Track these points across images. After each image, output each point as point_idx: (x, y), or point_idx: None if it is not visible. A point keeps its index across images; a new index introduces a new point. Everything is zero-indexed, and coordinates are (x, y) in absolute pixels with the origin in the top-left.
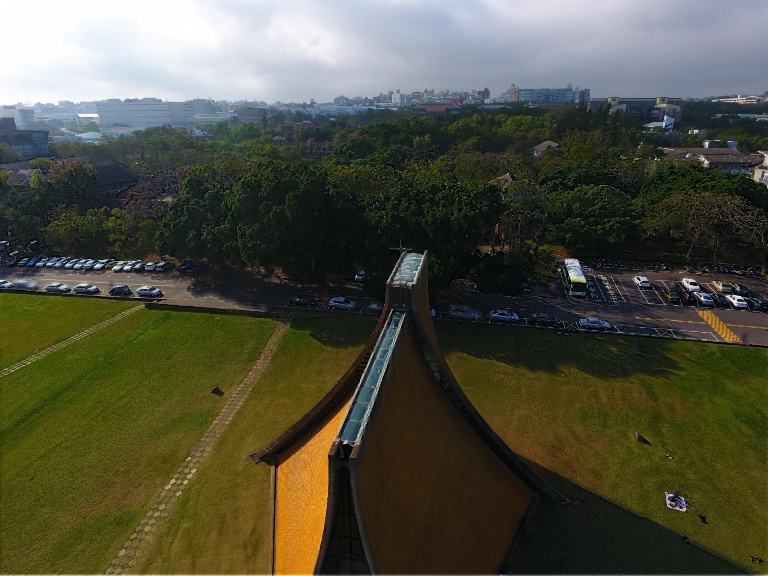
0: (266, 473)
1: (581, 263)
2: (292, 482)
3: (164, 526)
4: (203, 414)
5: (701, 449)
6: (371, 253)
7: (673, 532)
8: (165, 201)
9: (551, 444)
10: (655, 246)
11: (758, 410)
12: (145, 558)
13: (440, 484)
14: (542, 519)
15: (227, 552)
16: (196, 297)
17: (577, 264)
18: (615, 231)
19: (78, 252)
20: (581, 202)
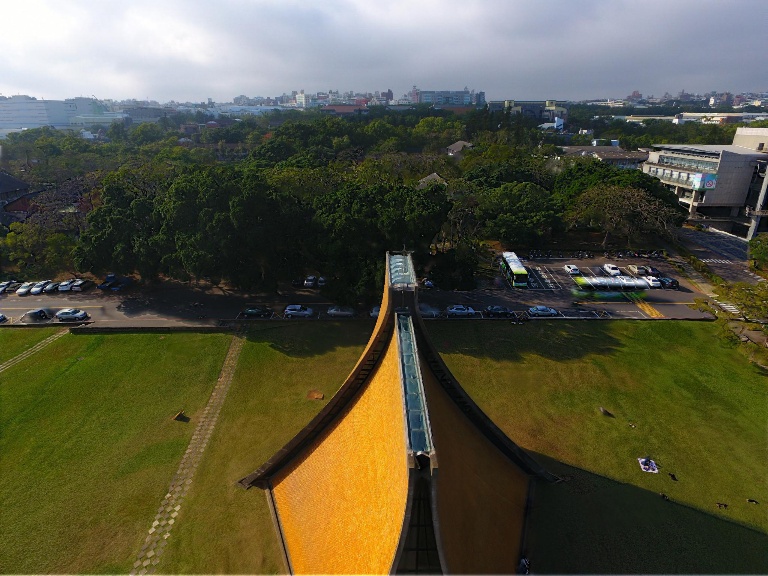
0: (261, 498)
1: None
2: (297, 503)
3: (159, 575)
4: (172, 444)
5: (655, 415)
6: (325, 257)
7: (653, 493)
8: (77, 212)
9: (531, 428)
10: (575, 236)
11: (691, 375)
12: None
13: (463, 481)
14: (543, 500)
15: None
16: (131, 317)
17: (515, 257)
18: (542, 224)
19: None
20: (507, 198)
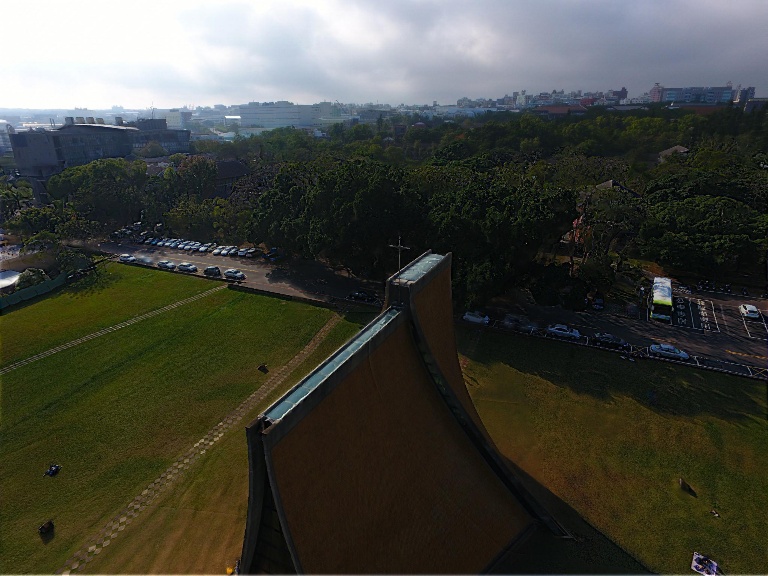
0: None
1: (678, 283)
2: None
3: (183, 477)
4: (245, 387)
5: (762, 513)
6: None
7: None
8: (261, 194)
9: (573, 473)
10: None
11: None
12: (160, 500)
13: (409, 486)
14: (533, 548)
15: (224, 510)
16: (271, 283)
17: (667, 284)
18: (726, 250)
19: (191, 235)
20: (691, 215)
